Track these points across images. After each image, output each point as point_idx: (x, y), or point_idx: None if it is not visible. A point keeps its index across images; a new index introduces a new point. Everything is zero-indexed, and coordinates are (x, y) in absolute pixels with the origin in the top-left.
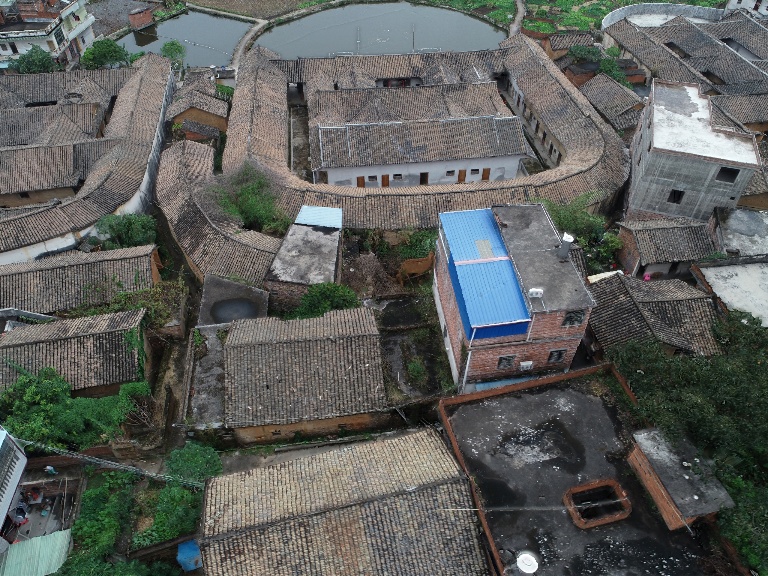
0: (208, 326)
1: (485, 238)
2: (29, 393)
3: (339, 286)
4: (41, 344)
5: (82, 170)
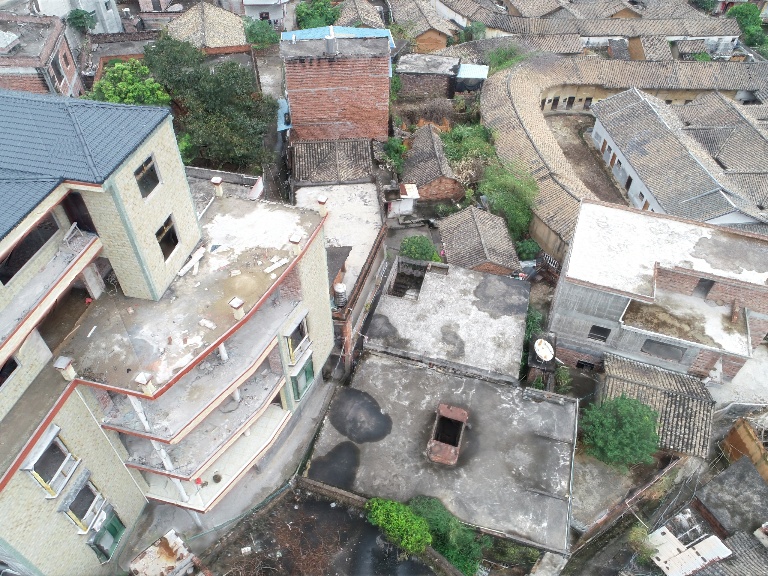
0: None
1: None
2: (319, 3)
3: (398, 77)
4: (354, 5)
5: None
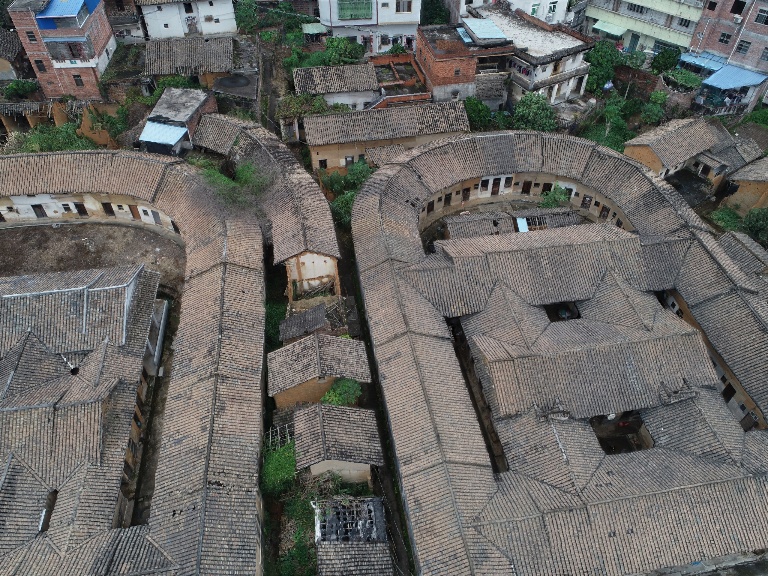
0: (249, 71)
1: (60, 3)
2: None
3: None
4: None
5: (437, 256)
